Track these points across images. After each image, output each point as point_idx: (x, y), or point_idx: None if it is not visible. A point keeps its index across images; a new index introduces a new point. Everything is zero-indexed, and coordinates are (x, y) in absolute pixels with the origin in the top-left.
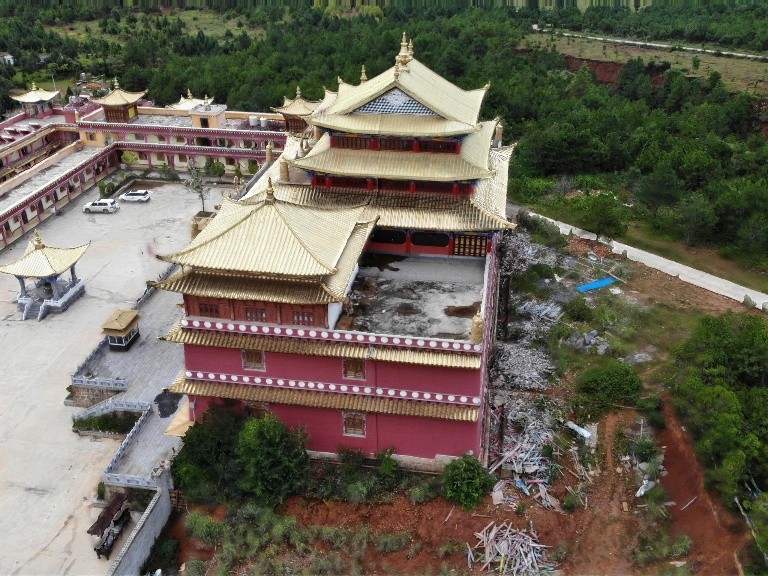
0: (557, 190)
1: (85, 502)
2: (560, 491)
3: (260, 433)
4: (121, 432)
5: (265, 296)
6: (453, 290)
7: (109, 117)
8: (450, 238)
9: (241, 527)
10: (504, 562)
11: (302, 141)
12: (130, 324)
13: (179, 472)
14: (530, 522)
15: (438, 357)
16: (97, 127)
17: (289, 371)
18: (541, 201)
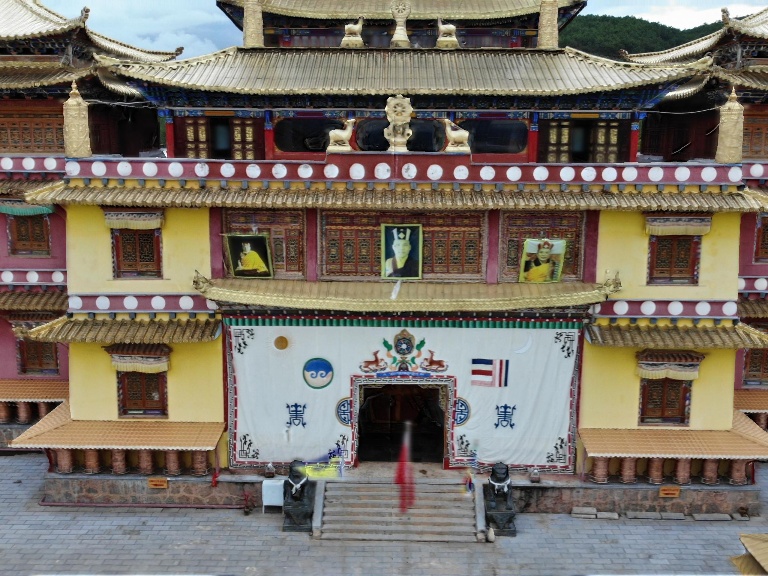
0: None
1: None
2: None
3: None
4: None
5: None
6: None
7: None
8: None
9: None
10: None
11: (393, 7)
12: None
13: None
14: None
15: None
16: None
17: None
18: None
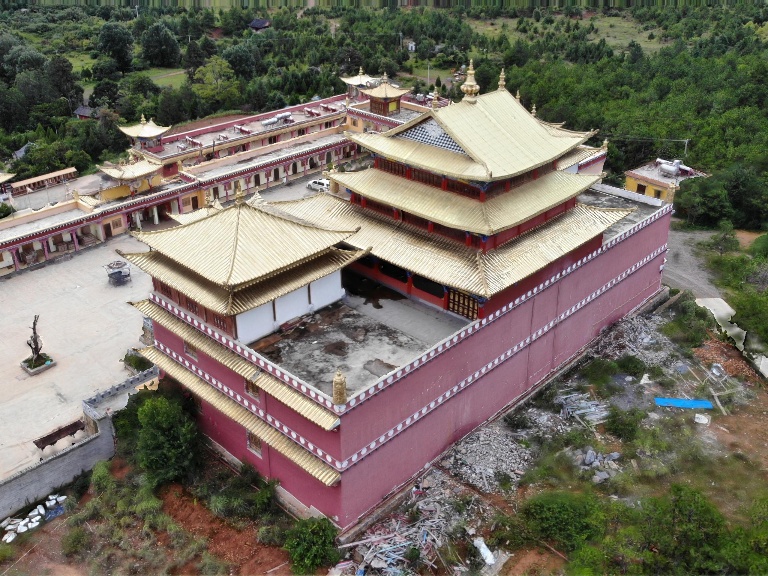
0: (753, 280)
1: None
2: None
3: (153, 414)
4: None
5: (187, 291)
6: (403, 345)
7: (373, 107)
8: (445, 291)
9: (123, 490)
10: None
11: None
12: None
13: (117, 423)
14: None
15: (303, 404)
16: (359, 115)
17: (212, 369)
18: (747, 289)
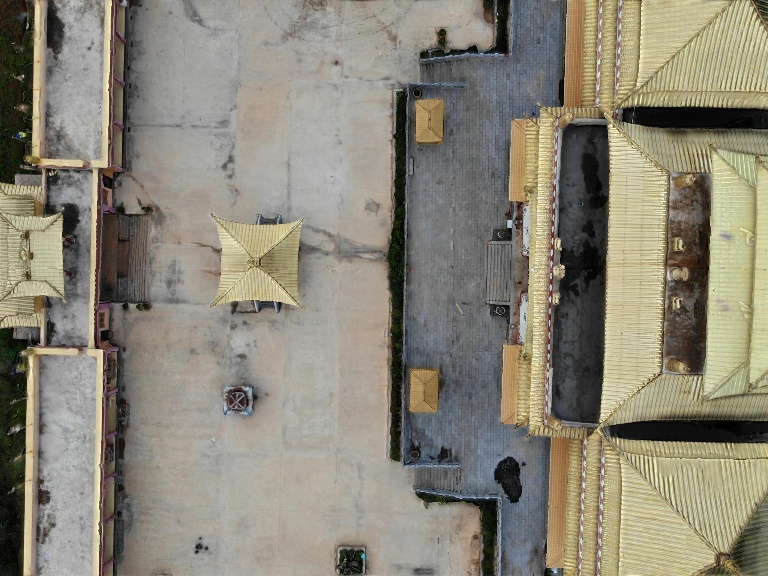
0: None
1: None
2: None
3: None
4: None
5: None
6: None
7: None
8: None
9: None
10: None
11: None
12: (438, 397)
13: None
14: None
15: None
16: None
17: None
18: None
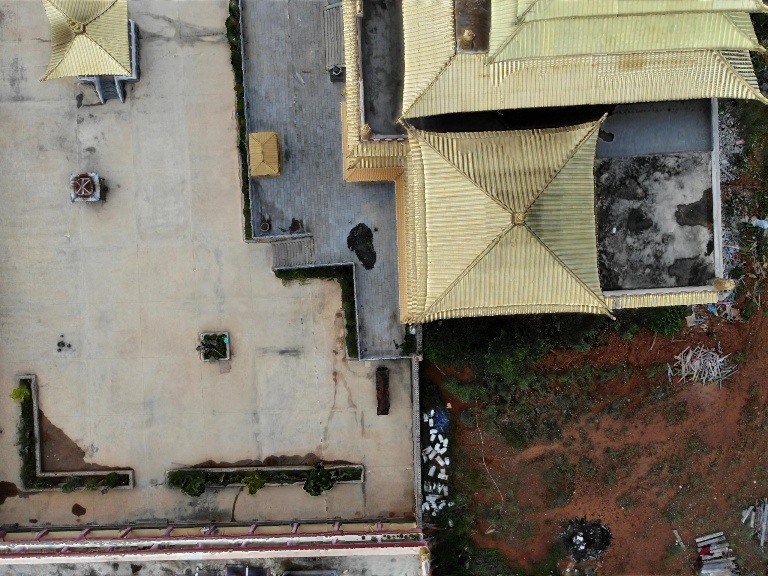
0: None
1: (338, 356)
2: (741, 302)
3: None
4: (328, 277)
5: (527, 310)
6: (679, 171)
7: None
8: None
9: None
10: (696, 374)
11: None
12: (278, 159)
13: None
14: (718, 343)
15: (679, 298)
16: None
17: None
18: None
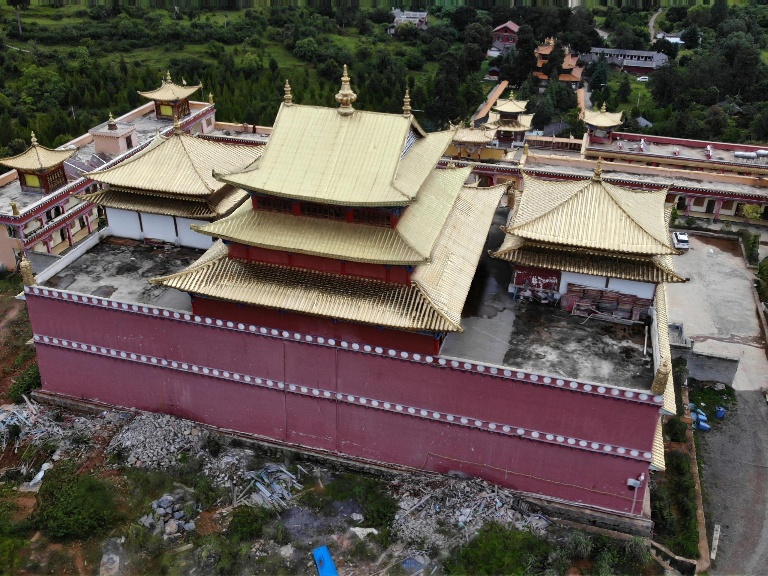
0: None
1: None
2: None
3: None
4: None
5: None
6: (145, 294)
7: None
8: None
9: None
10: None
11: None
12: None
13: None
14: None
15: None
16: None
17: None
18: None
